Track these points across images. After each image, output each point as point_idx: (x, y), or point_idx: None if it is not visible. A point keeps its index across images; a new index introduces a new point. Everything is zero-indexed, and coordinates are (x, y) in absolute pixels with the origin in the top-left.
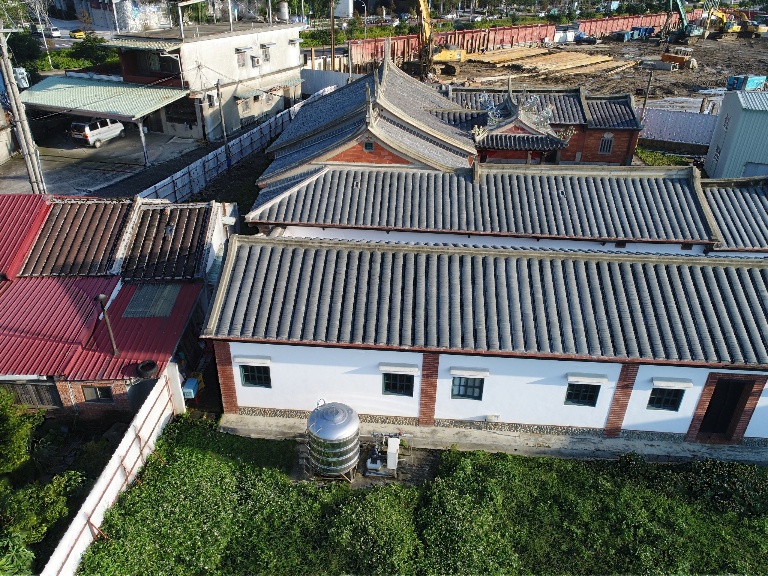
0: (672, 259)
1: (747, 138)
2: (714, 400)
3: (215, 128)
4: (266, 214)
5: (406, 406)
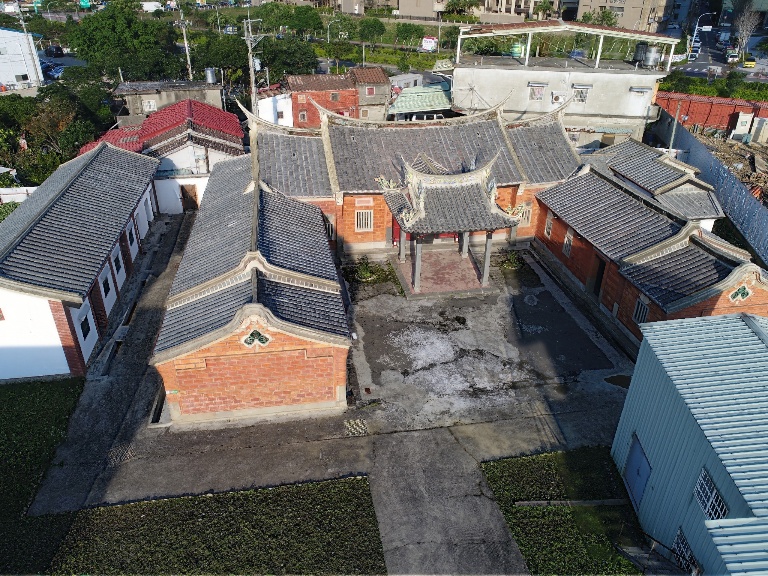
0: None
1: (641, 386)
2: None
3: None
4: None
5: None
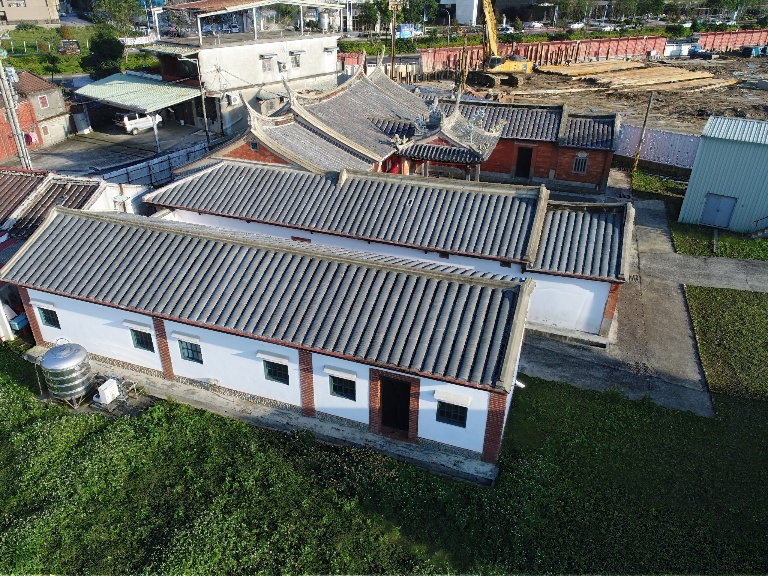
0: (373, 263)
1: (707, 167)
2: (392, 397)
3: (234, 124)
4: (158, 197)
5: (152, 360)
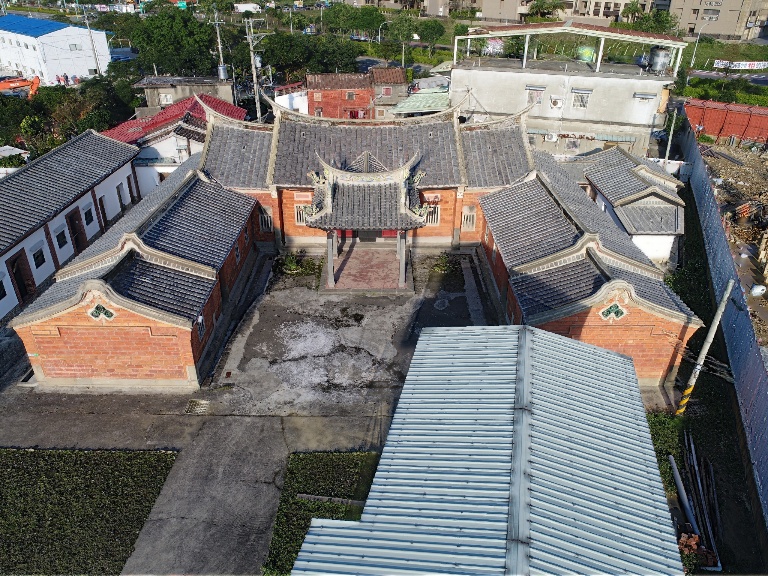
0: None
1: None
2: None
3: None
4: None
5: None
